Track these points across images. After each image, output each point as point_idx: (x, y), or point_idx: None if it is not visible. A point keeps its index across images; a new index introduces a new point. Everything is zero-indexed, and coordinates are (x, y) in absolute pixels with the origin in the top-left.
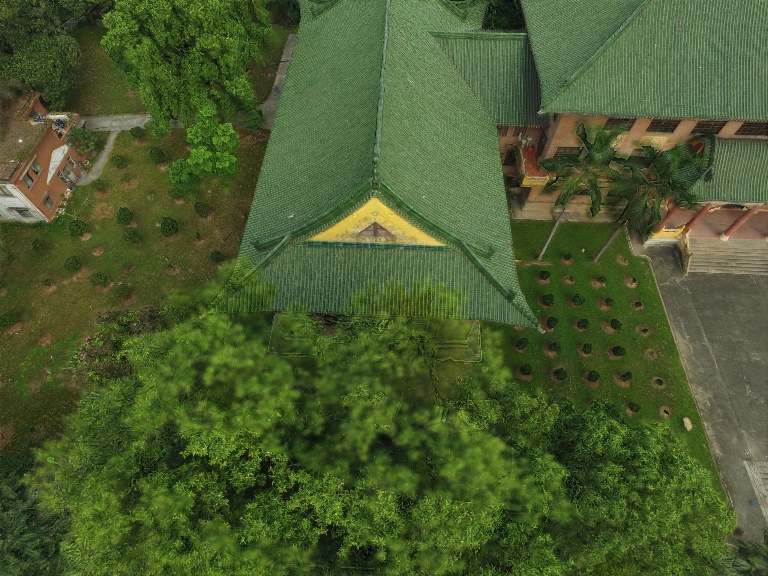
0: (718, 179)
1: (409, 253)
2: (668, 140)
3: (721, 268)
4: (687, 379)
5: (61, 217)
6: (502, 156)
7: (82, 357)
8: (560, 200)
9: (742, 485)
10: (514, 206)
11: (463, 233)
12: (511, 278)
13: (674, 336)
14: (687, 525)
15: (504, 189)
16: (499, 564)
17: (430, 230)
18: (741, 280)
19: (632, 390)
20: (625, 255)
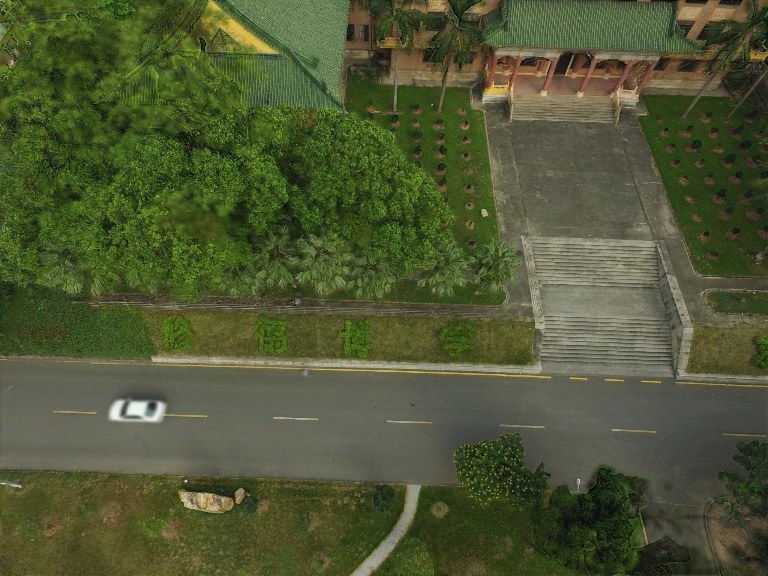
0: (515, 29)
1: (253, 61)
2: (484, 3)
3: (539, 116)
4: (493, 187)
5: (5, 81)
6: (368, 29)
7: (4, 125)
8: (380, 34)
9: (516, 249)
10: (383, 75)
11: (297, 50)
12: (334, 85)
13: (490, 161)
14: (395, 189)
15: (345, 33)
16: (231, 154)
17: (263, 37)
18: (553, 125)
19: (448, 193)
20: (465, 108)
